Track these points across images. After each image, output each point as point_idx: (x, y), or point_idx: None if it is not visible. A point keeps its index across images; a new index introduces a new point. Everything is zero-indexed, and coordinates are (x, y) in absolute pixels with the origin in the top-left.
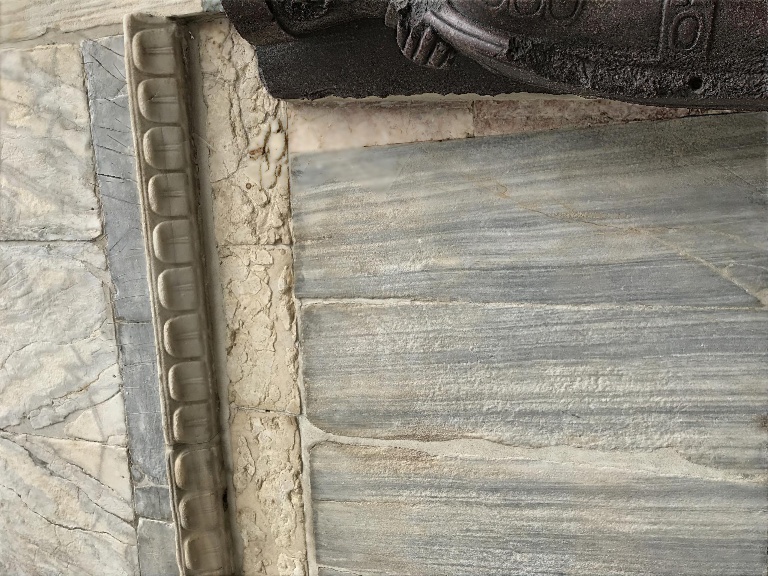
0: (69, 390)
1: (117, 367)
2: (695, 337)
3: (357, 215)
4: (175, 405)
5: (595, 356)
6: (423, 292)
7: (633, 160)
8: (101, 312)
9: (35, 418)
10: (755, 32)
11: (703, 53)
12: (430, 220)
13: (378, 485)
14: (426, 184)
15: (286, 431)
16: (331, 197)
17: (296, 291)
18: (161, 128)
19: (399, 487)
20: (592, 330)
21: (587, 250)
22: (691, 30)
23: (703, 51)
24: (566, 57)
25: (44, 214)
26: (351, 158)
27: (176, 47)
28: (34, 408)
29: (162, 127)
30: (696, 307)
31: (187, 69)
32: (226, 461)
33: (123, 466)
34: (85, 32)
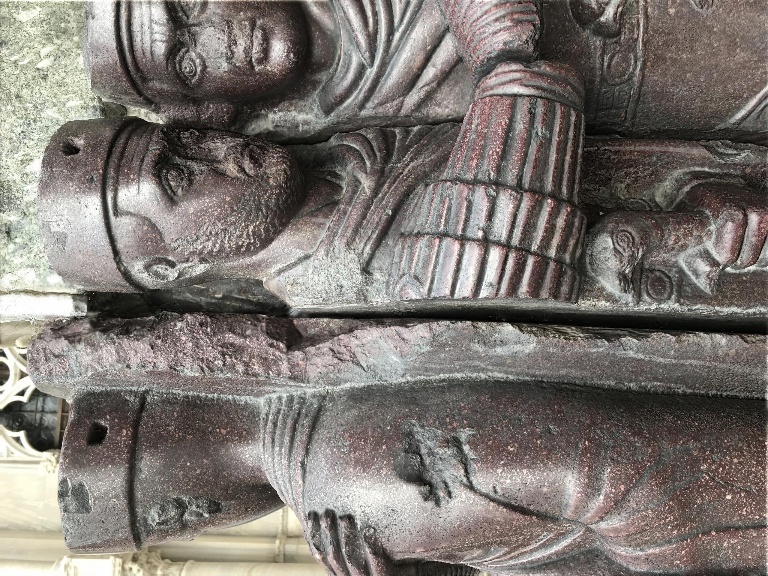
0: None
1: None
2: None
3: None
4: None
5: None
6: None
7: None
8: None
9: None
10: None
11: None
12: None
13: None
14: None
15: None
16: None
17: None
18: None
19: None
20: None
21: None
22: None
23: None
24: None
25: None
26: None
27: None
28: None
29: (3, 334)
30: None
31: None
32: None
33: None
34: None
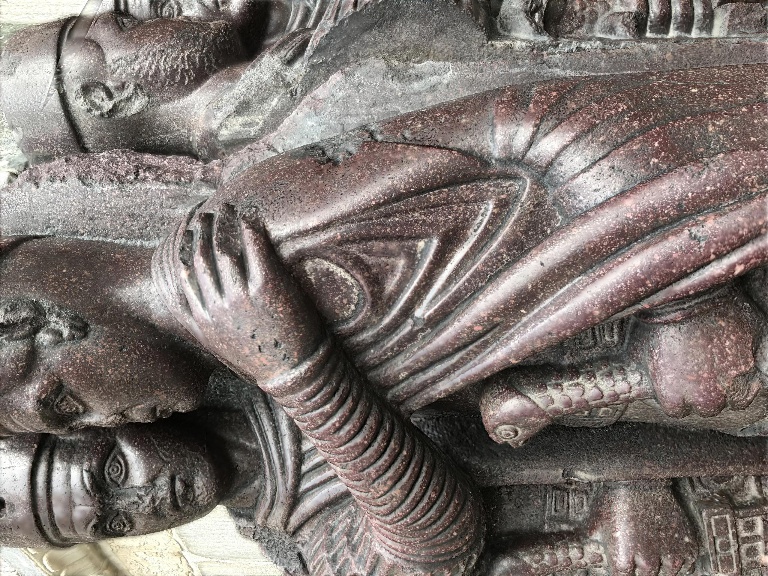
0: None
1: None
2: None
3: None
4: (59, 571)
5: None
6: None
7: None
8: None
9: None
10: None
11: None
12: None
13: None
14: None
15: (171, 557)
16: None
17: None
18: None
19: None
20: None
21: None
22: None
23: None
24: None
25: None
26: None
27: None
28: None
29: None
30: None
31: None
32: (119, 567)
33: None
34: None
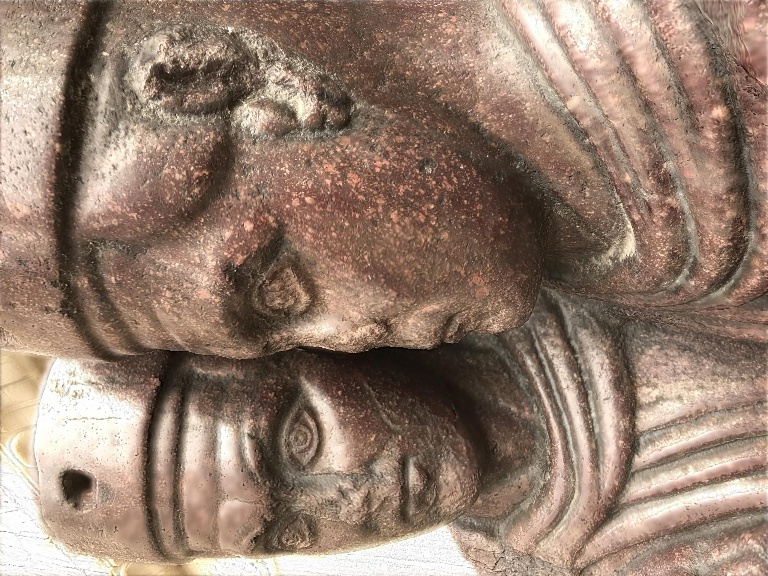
0: None
1: (6, 498)
2: None
3: None
4: None
5: None
6: None
7: None
8: None
9: None
10: None
11: None
12: None
13: (349, 571)
14: None
15: None
16: None
17: None
18: None
19: (371, 573)
20: None
21: None
22: None
23: None
24: None
25: None
26: None
27: None
28: None
29: None
30: None
31: None
32: None
33: (50, 549)
34: None
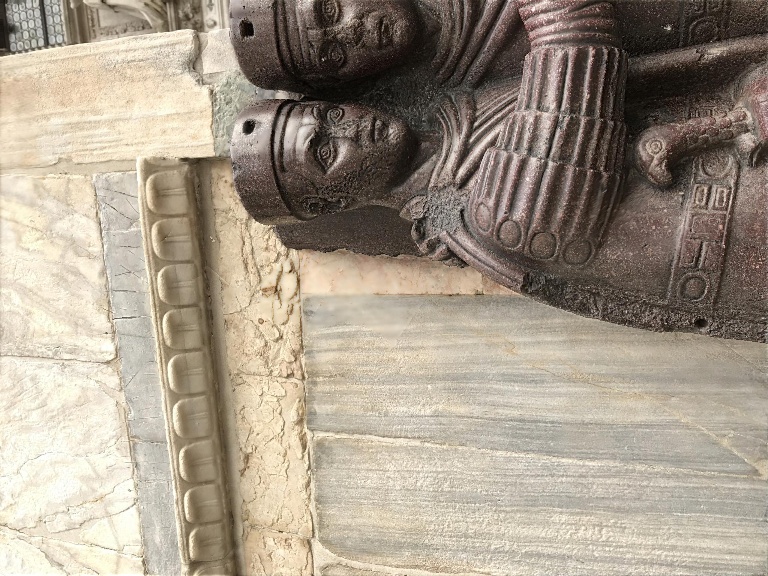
0: (84, 500)
1: (132, 482)
2: (695, 499)
3: (368, 358)
4: (190, 527)
5: (599, 508)
6: (433, 435)
7: (638, 330)
8: (116, 430)
9: (51, 523)
10: (759, 296)
11: (709, 305)
12: (440, 369)
13: None
14: (436, 335)
15: (299, 552)
16: (343, 338)
17: (308, 423)
18: (175, 266)
19: None
20: (597, 484)
21: (592, 409)
22: (698, 288)
23: (709, 304)
24: (578, 290)
25: (58, 334)
26: (362, 304)
27: (189, 187)
28: (50, 513)
29: (176, 265)
30: (697, 471)
31: (199, 205)
32: (240, 574)
33: (139, 575)
34: (97, 165)
